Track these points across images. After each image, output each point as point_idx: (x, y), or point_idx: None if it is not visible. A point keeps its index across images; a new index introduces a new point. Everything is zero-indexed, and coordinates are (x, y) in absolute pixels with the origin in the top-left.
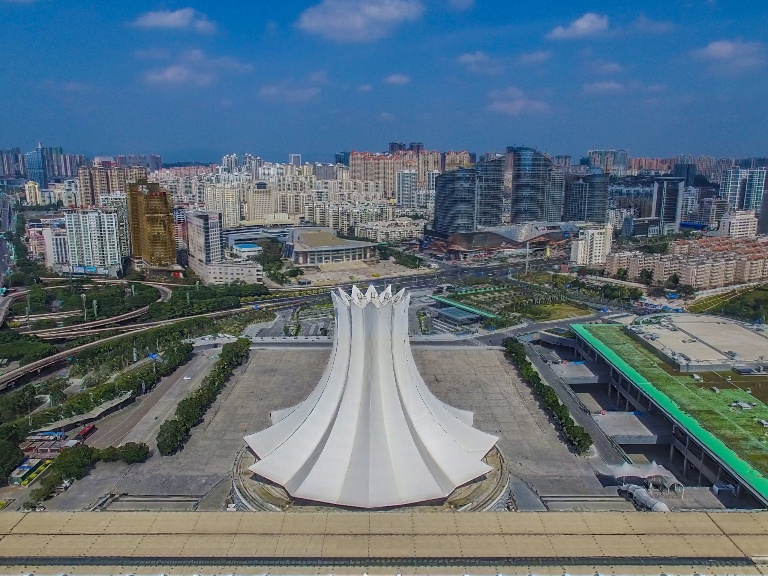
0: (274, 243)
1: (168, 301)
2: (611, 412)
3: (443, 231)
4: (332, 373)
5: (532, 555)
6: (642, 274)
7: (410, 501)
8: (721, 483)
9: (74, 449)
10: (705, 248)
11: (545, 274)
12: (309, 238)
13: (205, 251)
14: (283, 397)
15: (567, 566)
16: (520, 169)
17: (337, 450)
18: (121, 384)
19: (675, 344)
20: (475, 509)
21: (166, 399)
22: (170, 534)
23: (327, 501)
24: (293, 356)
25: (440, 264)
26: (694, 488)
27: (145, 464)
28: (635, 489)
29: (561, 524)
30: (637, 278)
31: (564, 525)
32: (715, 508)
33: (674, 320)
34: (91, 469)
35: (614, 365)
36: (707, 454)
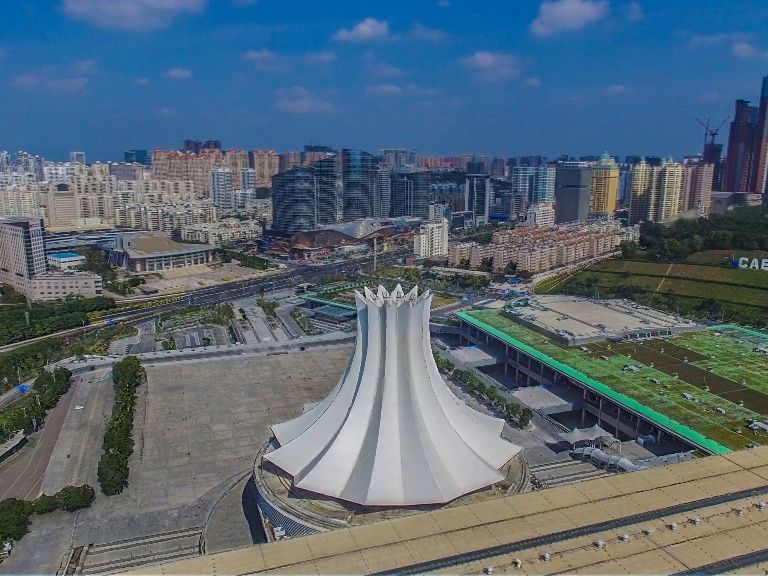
0: (95, 251)
1: (1, 323)
2: (525, 388)
3: (284, 230)
4: (364, 376)
5: (630, 514)
6: (483, 263)
7: (470, 490)
8: (641, 435)
9: (3, 505)
10: (524, 237)
11: (393, 268)
12: (142, 243)
13: (26, 263)
14: (208, 414)
15: (663, 517)
16: (350, 167)
17: (387, 452)
18: (7, 424)
19: (553, 322)
20: (520, 487)
21: (67, 434)
22: (292, 565)
23: (395, 504)
24: (192, 370)
25: (286, 264)
26: (624, 443)
27: (92, 508)
28: (592, 450)
29: (629, 484)
30: (479, 267)
31: (632, 485)
32: (648, 457)
33: (540, 301)
34: (27, 525)
35: (514, 346)
36: (630, 412)
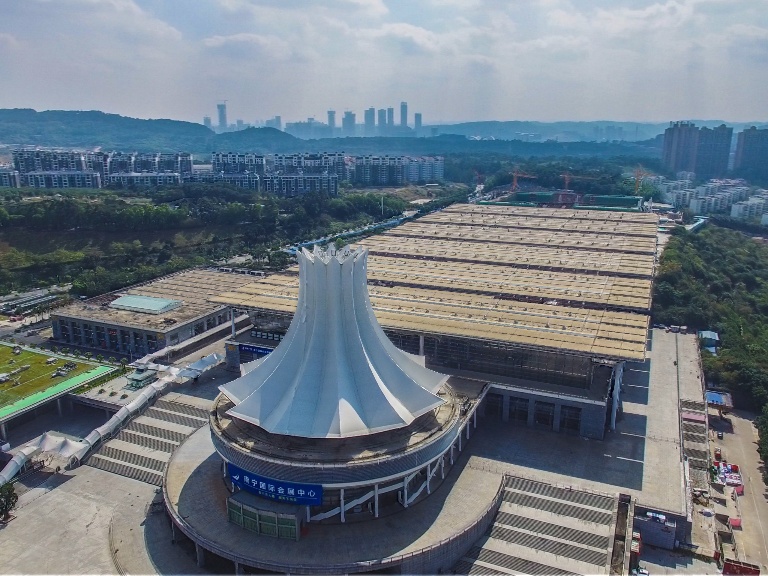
0: None
1: None
2: None
3: None
4: None
5: None
6: None
7: None
8: None
9: None
10: None
11: None
12: None
13: None
14: None
15: None
16: None
17: None
18: None
19: None
20: None
21: None
22: None
23: None
24: None
25: None
26: None
27: None
28: None
29: None
30: None
31: None
32: None
33: None
34: None
35: None
36: None
